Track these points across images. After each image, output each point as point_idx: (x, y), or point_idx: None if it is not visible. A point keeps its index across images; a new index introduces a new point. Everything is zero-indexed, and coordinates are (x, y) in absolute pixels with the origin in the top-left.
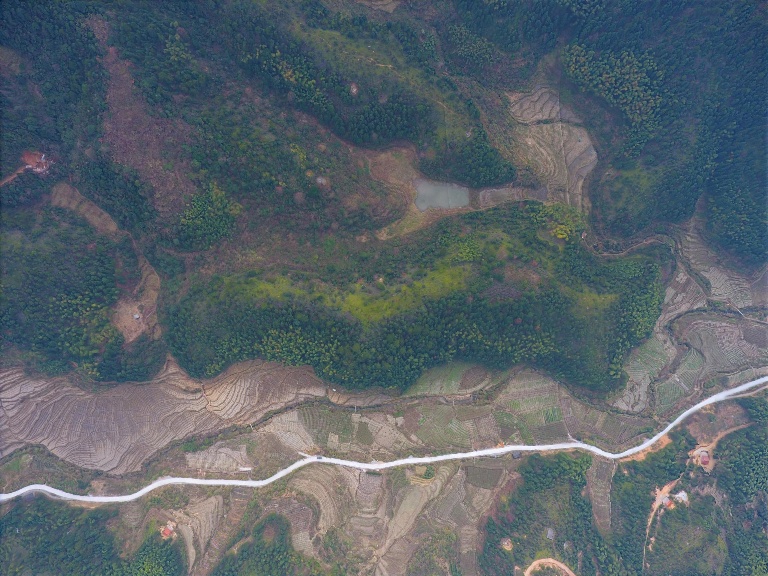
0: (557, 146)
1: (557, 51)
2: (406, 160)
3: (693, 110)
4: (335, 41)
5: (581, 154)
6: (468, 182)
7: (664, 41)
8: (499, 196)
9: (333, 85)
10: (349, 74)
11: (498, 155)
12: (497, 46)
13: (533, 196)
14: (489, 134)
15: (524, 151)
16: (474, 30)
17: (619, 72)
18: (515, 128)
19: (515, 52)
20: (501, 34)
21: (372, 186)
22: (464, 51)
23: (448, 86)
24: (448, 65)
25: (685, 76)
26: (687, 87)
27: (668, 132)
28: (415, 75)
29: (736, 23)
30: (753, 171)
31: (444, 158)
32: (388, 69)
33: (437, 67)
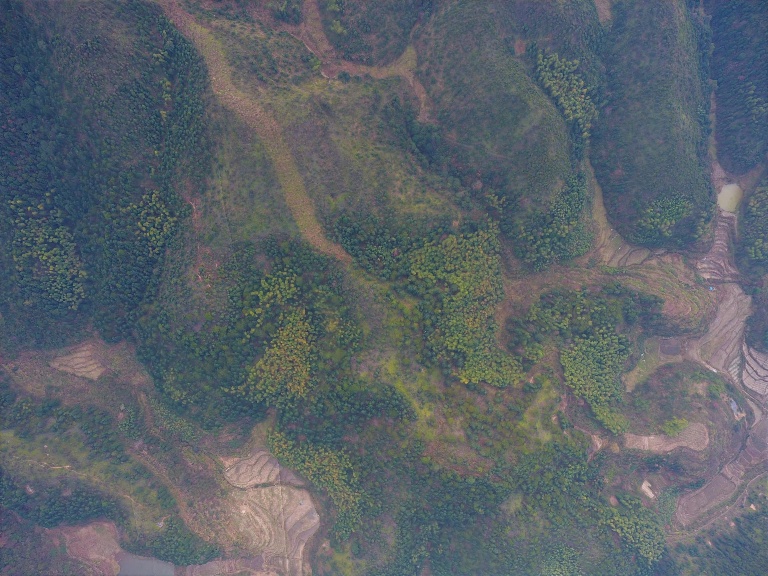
0: (276, 511)
1: (270, 420)
2: (108, 534)
3: (391, 511)
4: (2, 450)
5: (302, 518)
6: (170, 561)
7: (358, 443)
8: (208, 569)
9: (4, 489)
10: (20, 480)
11: (192, 545)
12: (199, 424)
13: (247, 566)
14: (187, 518)
15: (236, 522)
16: (173, 410)
17: (318, 464)
18: (230, 493)
19: (218, 431)
20: (197, 420)
21: (64, 570)
22: (167, 426)
23: (136, 478)
24: (149, 442)
25: (377, 483)
26: (381, 493)
27: (369, 528)
28: (98, 471)
29: (410, 456)
30: (459, 569)
31: (138, 544)
32: (65, 470)
33: (134, 447)
